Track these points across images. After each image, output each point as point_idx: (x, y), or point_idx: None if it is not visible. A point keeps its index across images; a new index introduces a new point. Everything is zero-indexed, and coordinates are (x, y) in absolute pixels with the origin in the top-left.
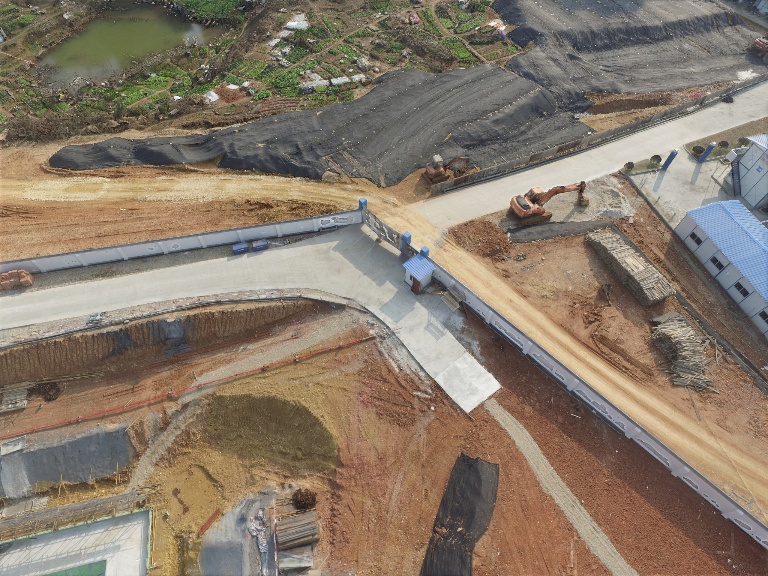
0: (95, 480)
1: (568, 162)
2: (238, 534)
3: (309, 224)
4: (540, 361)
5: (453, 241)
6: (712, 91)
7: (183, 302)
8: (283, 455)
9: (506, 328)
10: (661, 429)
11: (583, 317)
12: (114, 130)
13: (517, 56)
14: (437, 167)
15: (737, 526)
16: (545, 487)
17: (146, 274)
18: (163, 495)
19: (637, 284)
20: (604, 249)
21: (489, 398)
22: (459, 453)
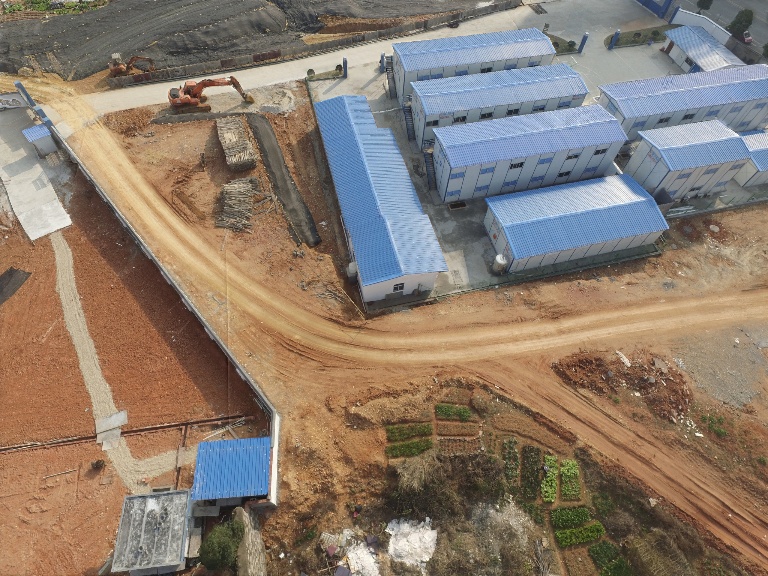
0: None
1: (262, 70)
2: None
3: None
4: None
5: (102, 122)
6: None
7: None
8: None
9: None
10: (183, 255)
11: (175, 179)
12: None
13: None
14: (117, 64)
15: None
16: (58, 288)
17: None
18: None
19: None
20: None
21: (56, 231)
22: (9, 267)
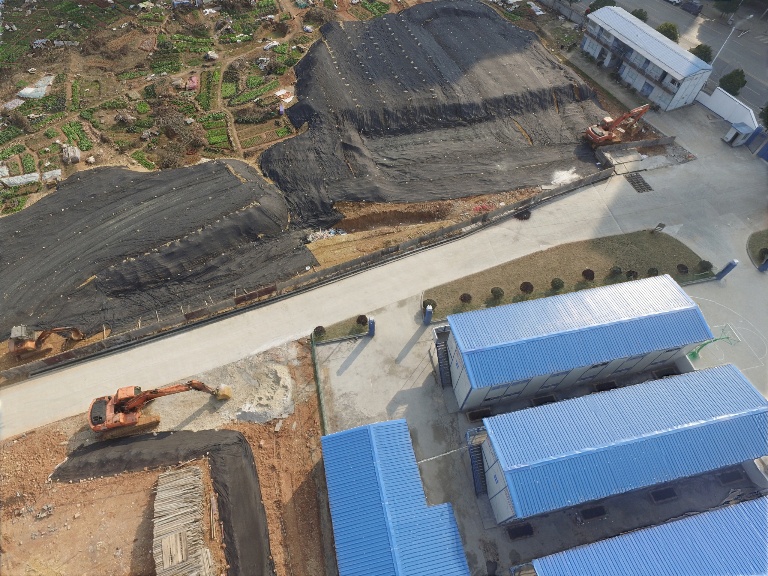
0: None
1: (248, 318)
2: None
3: None
4: None
5: None
6: (507, 201)
7: None
8: None
9: None
10: None
11: None
12: None
13: (278, 144)
14: (20, 342)
15: None
16: None
17: None
18: None
19: None
20: None
21: None
22: None
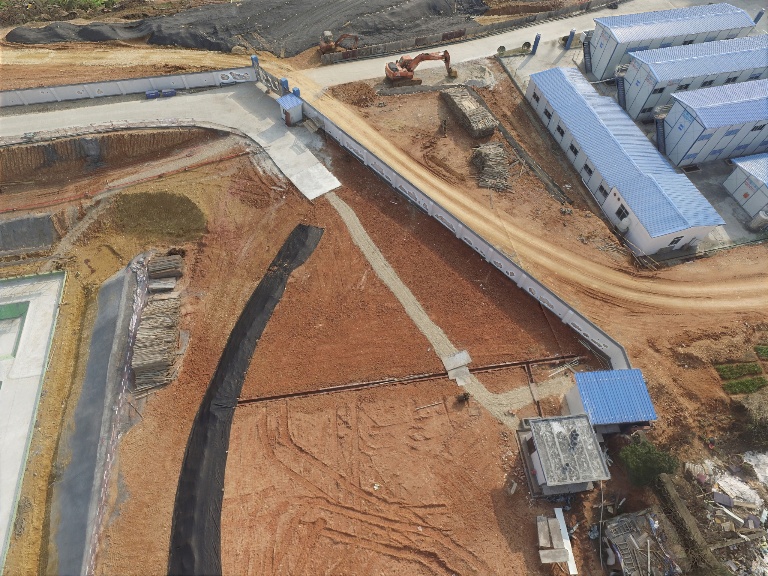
0: (26, 254)
1: (451, 48)
2: (124, 273)
3: (211, 78)
4: (377, 170)
5: (330, 94)
6: None
7: (100, 128)
8: (170, 235)
9: (352, 145)
10: (459, 212)
11: (421, 144)
12: (64, 18)
13: None
14: (328, 42)
15: (495, 267)
16: (356, 241)
17: (74, 110)
18: (77, 263)
19: (467, 119)
20: (449, 97)
21: (330, 191)
22: (298, 224)
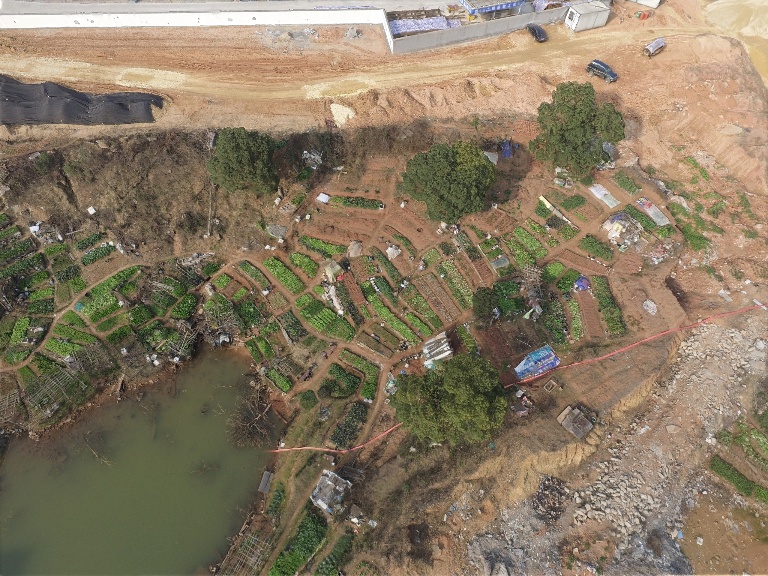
0: None
1: None
2: None
3: None
4: None
5: None
6: None
7: (86, 2)
8: None
9: None
10: None
11: None
12: None
13: None
14: None
15: None
16: None
17: None
18: None
19: None
20: None
21: None
22: None
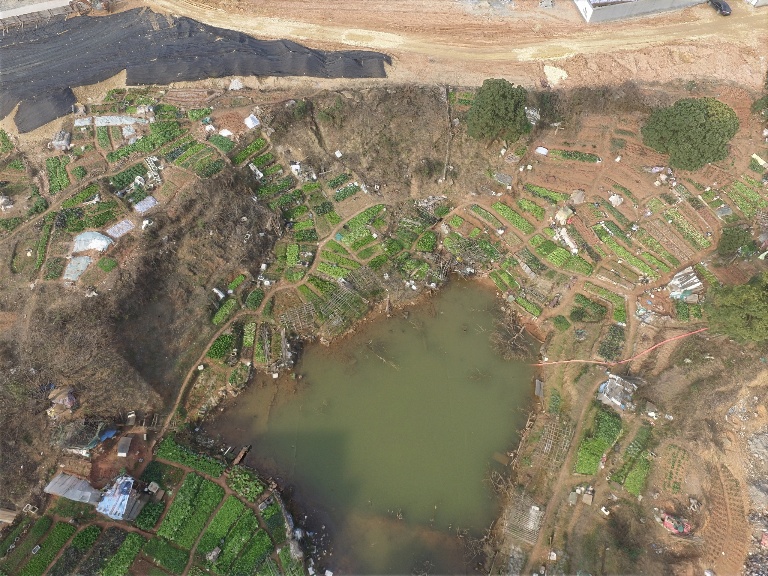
0: None
1: None
2: None
3: None
4: None
5: None
6: None
7: None
8: None
9: None
10: None
11: None
12: None
13: None
14: None
15: None
16: None
17: None
18: None
19: None
20: None
21: None
22: None
